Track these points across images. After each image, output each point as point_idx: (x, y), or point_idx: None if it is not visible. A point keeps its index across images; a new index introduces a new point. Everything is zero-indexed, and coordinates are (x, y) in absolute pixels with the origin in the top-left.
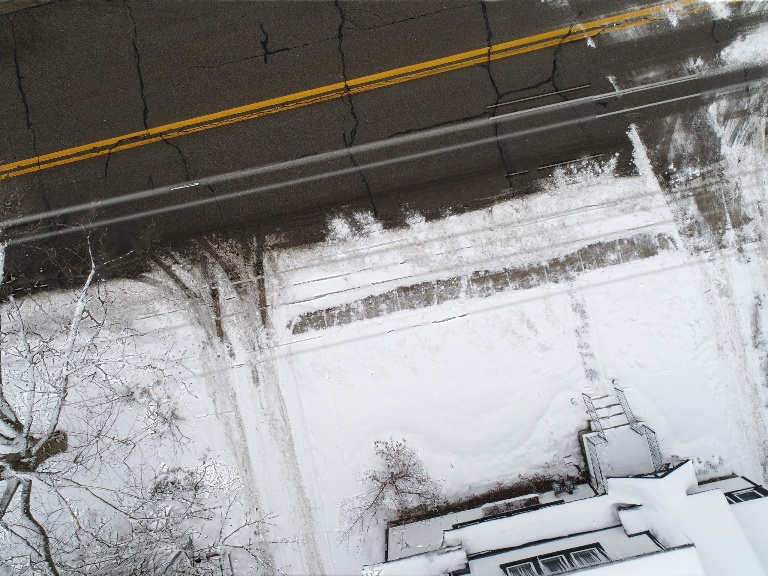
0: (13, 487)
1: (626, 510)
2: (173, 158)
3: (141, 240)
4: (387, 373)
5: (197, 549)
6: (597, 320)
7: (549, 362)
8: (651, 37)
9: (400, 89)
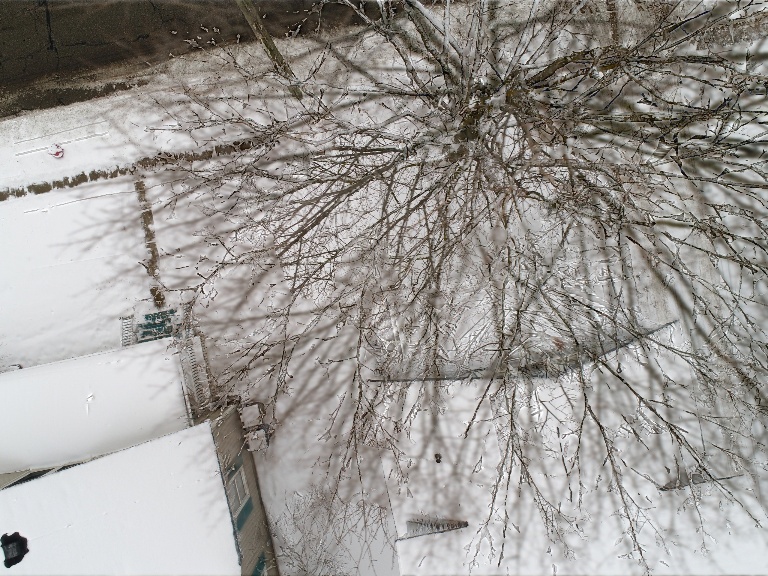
0: None
1: None
2: None
3: None
4: None
5: None
6: None
7: None
8: None
9: None
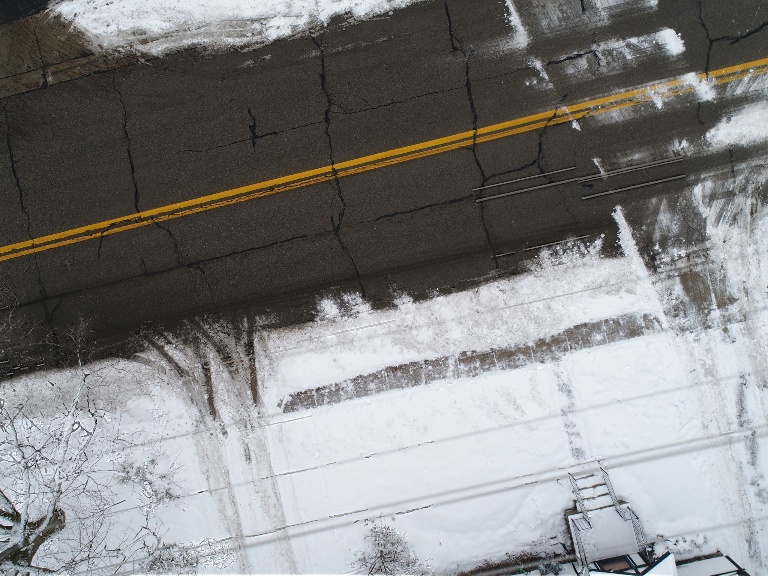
0: None
1: None
2: (164, 241)
3: (134, 321)
4: None
5: None
6: (583, 400)
7: (535, 442)
8: (636, 119)
9: (387, 172)
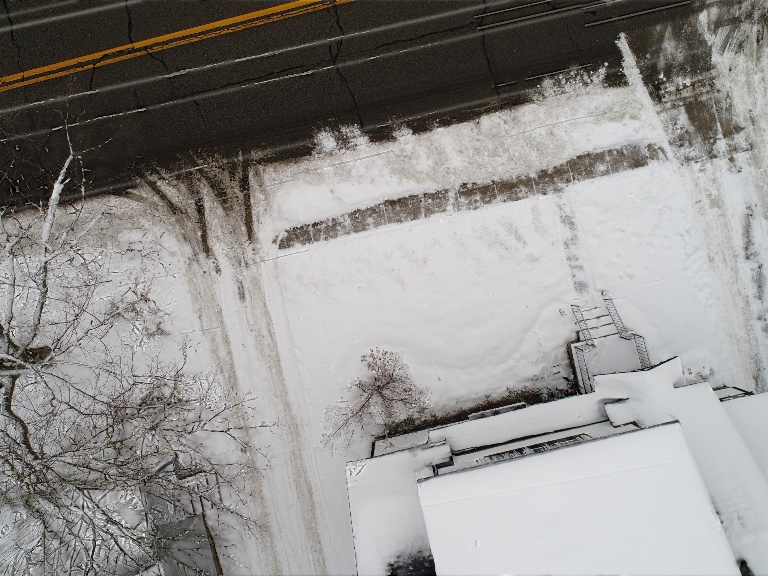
0: None
1: (612, 403)
2: (158, 72)
3: (126, 156)
4: (374, 286)
5: None
6: (586, 231)
7: (537, 274)
8: None
9: None
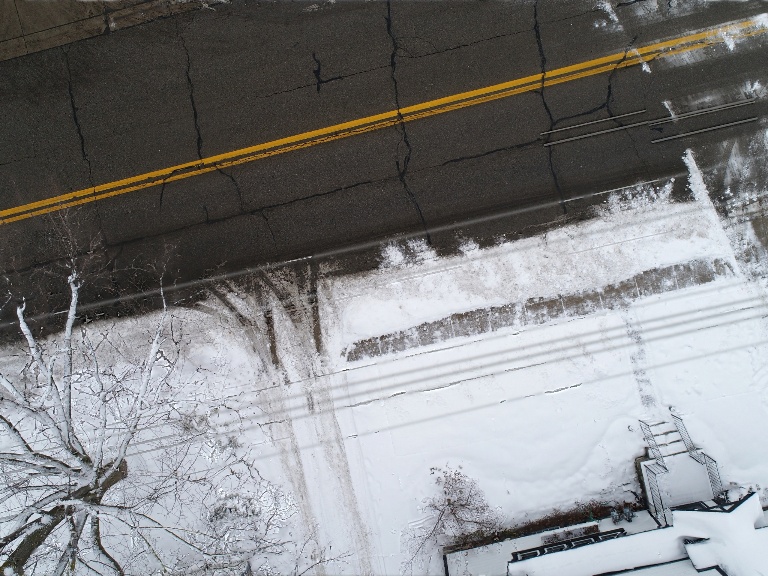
0: (83, 519)
1: (693, 544)
2: (227, 187)
3: (196, 269)
4: (442, 400)
5: (255, 574)
6: (653, 347)
7: (605, 389)
8: (707, 61)
9: (453, 116)
